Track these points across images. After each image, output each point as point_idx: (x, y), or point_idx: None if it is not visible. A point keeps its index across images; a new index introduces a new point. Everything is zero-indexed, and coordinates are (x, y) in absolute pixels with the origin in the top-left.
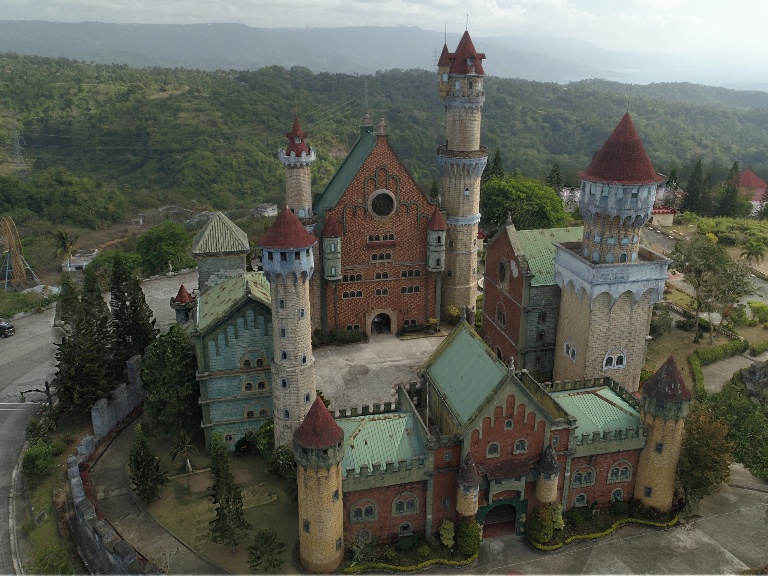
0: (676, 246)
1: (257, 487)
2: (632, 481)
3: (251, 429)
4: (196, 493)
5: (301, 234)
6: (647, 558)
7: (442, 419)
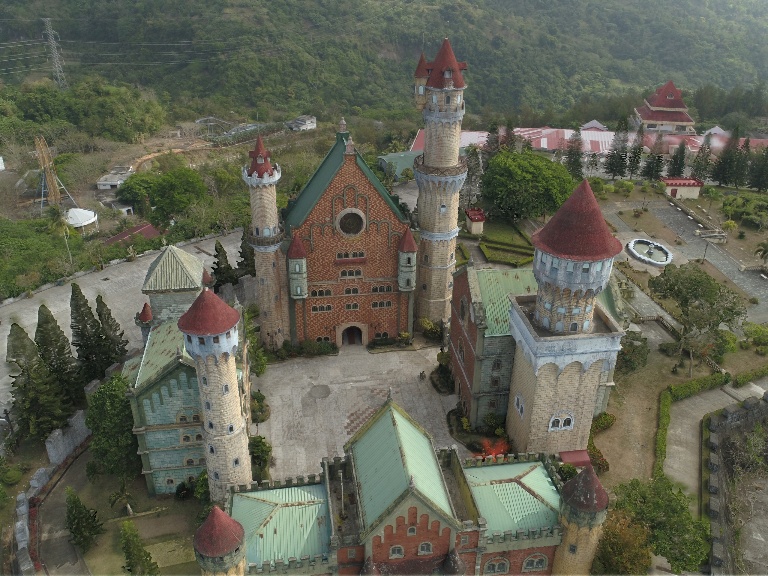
0: (665, 270)
1: (189, 539)
2: (548, 570)
3: (192, 474)
4: None
5: (220, 318)
6: None
7: None
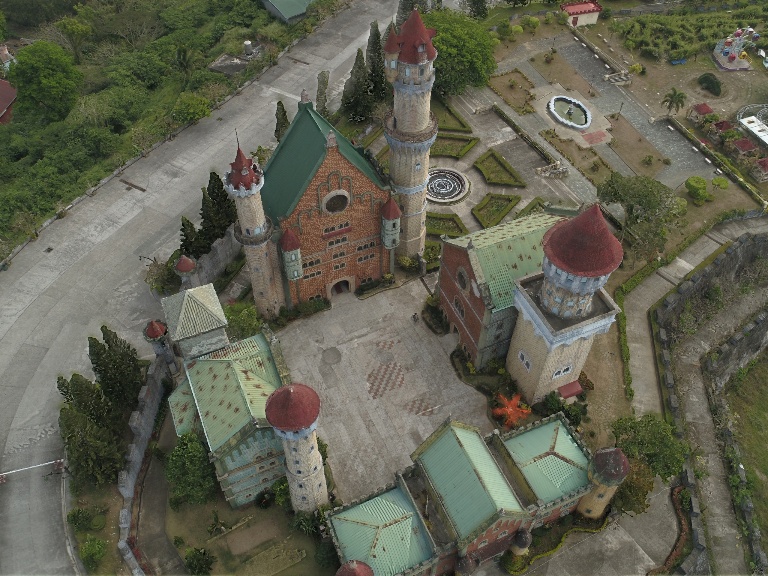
0: (613, 181)
1: (286, 542)
2: None
3: (266, 486)
4: (238, 556)
5: (308, 410)
6: (586, 567)
7: (438, 507)
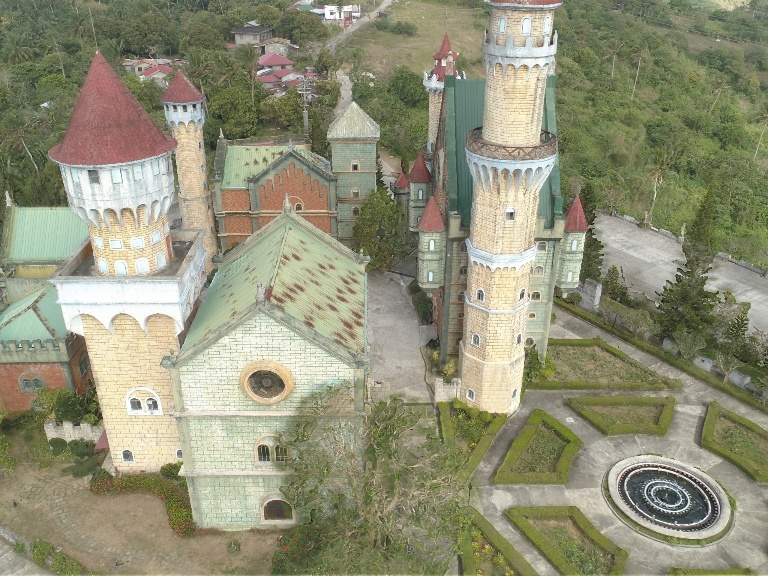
0: (427, 570)
1: None
2: None
3: None
4: None
5: None
6: None
7: None
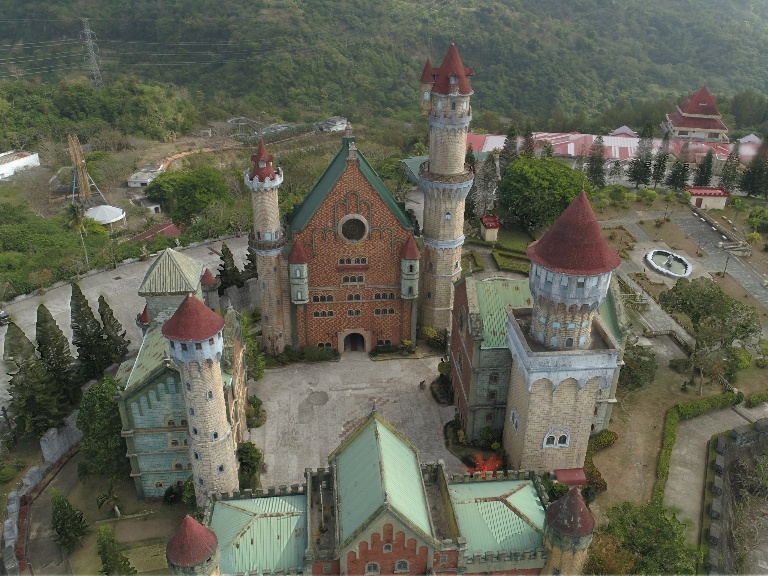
0: (677, 284)
1: None
2: None
3: (180, 478)
4: (117, 544)
5: (203, 324)
6: None
7: None
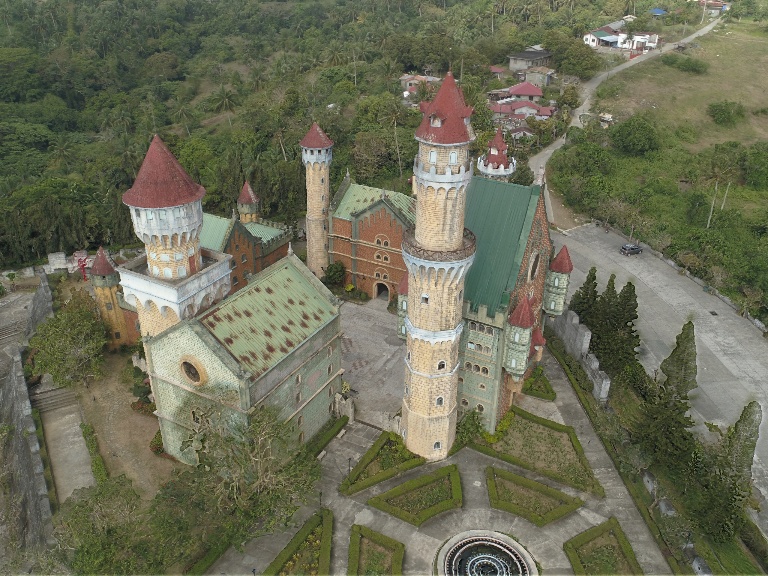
0: None
1: None
2: None
3: None
4: None
5: None
6: None
7: None
